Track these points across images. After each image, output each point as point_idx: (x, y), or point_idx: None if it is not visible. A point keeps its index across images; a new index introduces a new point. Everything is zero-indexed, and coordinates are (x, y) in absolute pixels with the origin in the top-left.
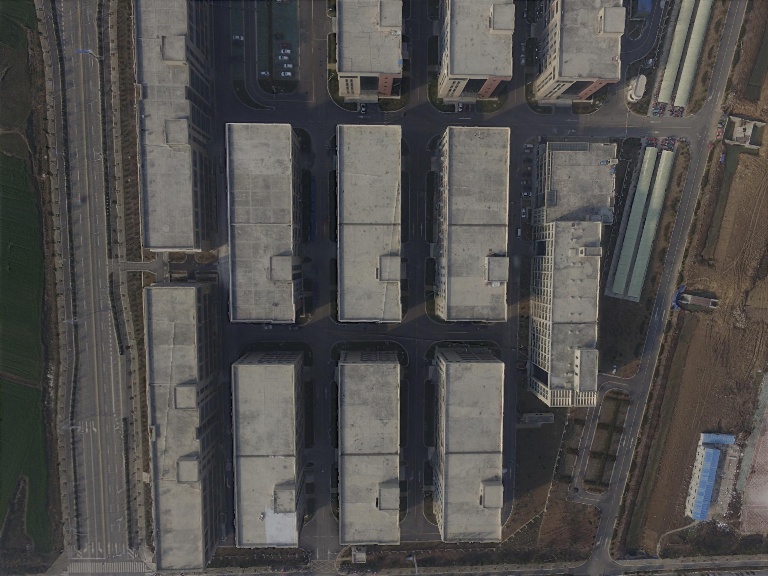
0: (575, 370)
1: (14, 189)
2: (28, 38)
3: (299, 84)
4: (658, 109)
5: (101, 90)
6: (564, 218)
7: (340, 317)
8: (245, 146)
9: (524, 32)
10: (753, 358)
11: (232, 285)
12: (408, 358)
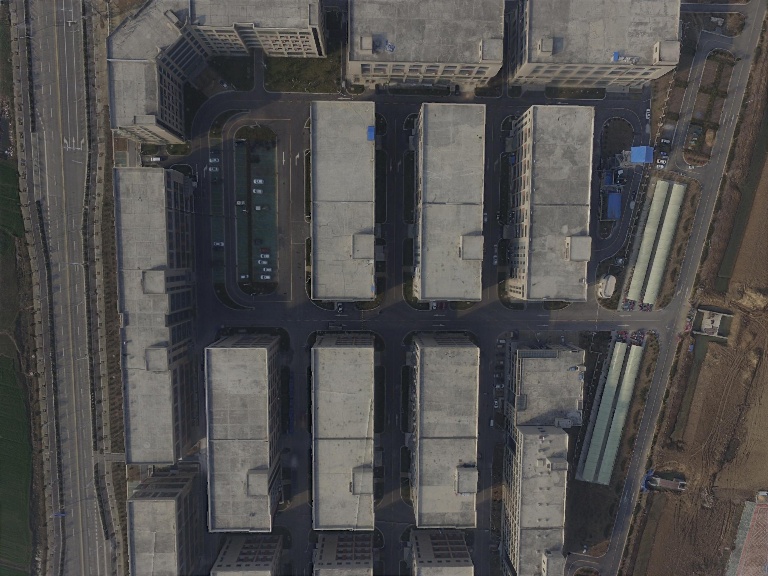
0: (542, 573)
1: (3, 386)
2: (16, 245)
3: (278, 286)
4: (628, 305)
5: (86, 294)
6: (534, 420)
7: (315, 525)
8: (223, 368)
9: (497, 234)
10: (720, 536)
11: (211, 497)
12: (384, 540)
